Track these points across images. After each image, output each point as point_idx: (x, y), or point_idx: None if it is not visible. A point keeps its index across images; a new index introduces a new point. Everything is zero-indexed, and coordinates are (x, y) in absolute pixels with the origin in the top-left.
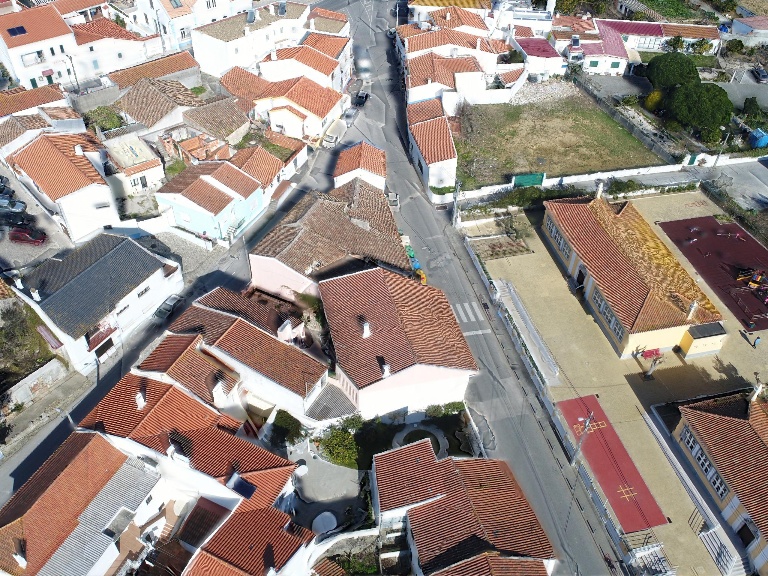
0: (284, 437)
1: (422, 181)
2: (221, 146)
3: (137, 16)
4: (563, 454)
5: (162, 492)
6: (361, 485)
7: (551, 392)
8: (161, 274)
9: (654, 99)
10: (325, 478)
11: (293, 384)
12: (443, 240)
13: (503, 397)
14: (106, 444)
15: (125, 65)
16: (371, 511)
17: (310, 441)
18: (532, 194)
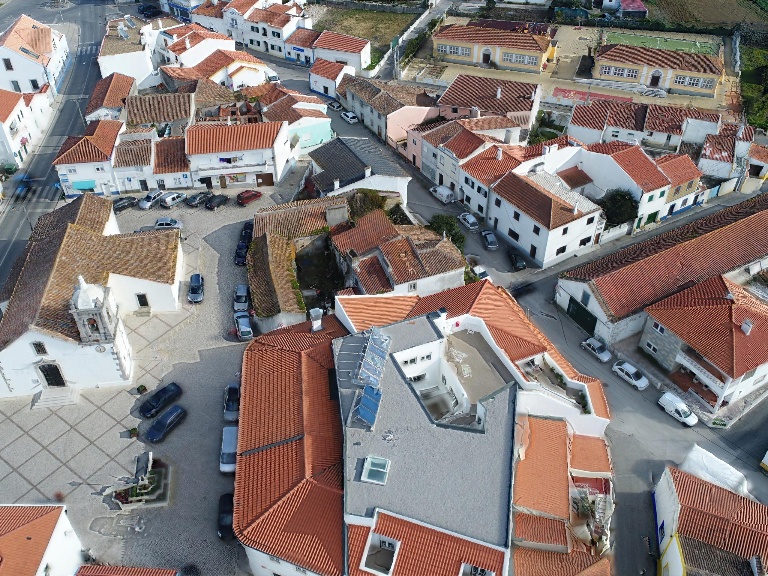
0: None
1: None
2: (239, 107)
3: None
4: None
5: None
6: None
7: None
8: None
9: None
10: None
11: (511, 125)
12: None
13: None
14: (517, 174)
15: (48, 119)
16: None
17: None
18: (415, 42)
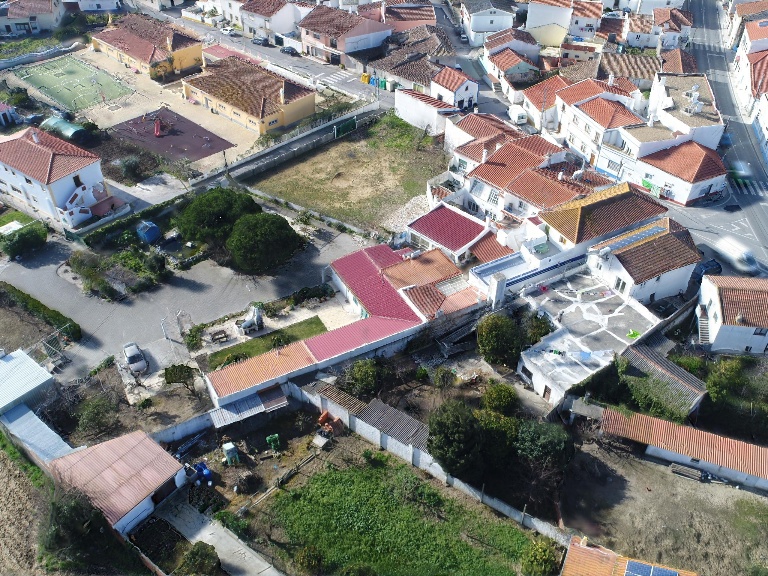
0: None
1: None
2: None
3: None
4: None
5: None
6: None
7: None
8: None
9: None
10: None
11: (365, 5)
12: None
13: None
14: None
15: None
16: None
17: None
18: None
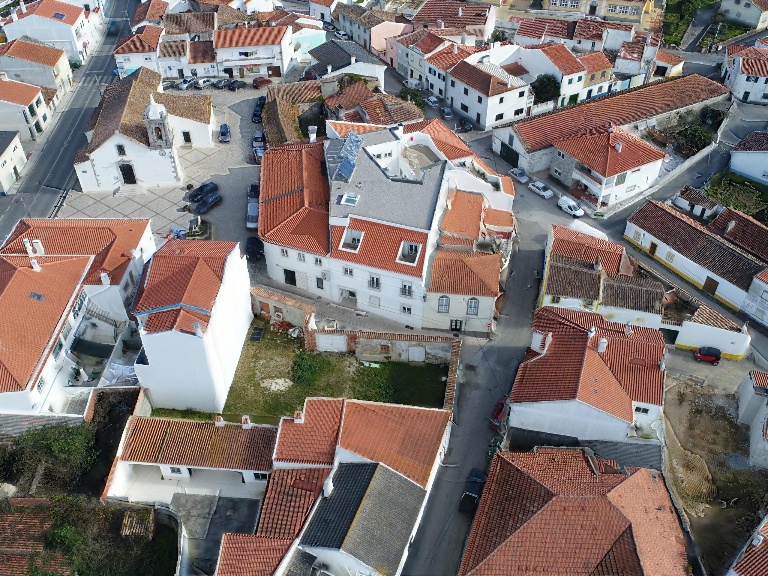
0: None
1: None
2: None
3: None
4: None
5: None
6: None
7: None
8: None
9: None
10: None
11: (468, 34)
12: None
13: None
14: None
15: (100, 33)
16: None
17: None
18: None
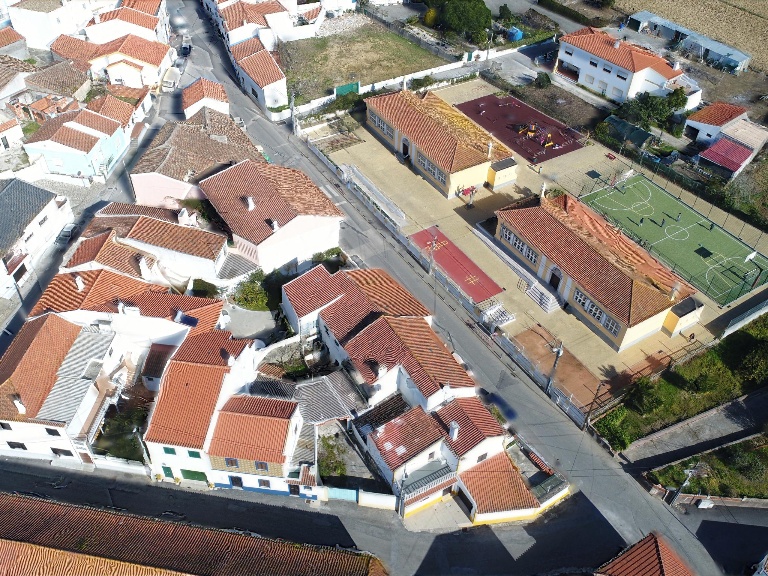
0: (205, 296)
1: (259, 106)
2: (70, 103)
3: None
4: (422, 269)
5: (120, 345)
6: (276, 319)
7: (403, 230)
8: (55, 204)
9: (431, 16)
10: (246, 322)
11: (202, 253)
12: (290, 146)
13: (368, 243)
14: (61, 320)
15: None
16: (290, 328)
17: (227, 296)
18: (353, 97)
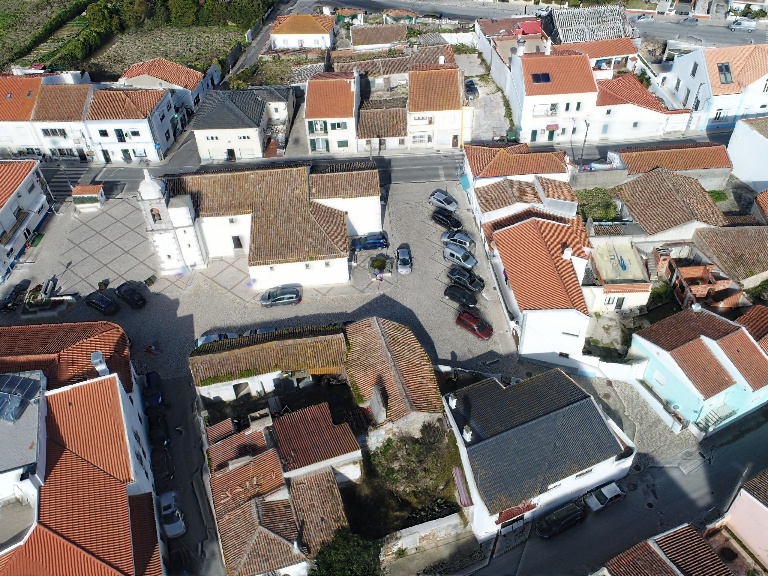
0: None
1: None
2: (731, 288)
3: (667, 78)
4: None
5: None
6: None
7: None
8: (613, 459)
9: None
10: None
11: None
12: None
13: None
14: None
15: (636, 136)
16: None
17: None
18: None
